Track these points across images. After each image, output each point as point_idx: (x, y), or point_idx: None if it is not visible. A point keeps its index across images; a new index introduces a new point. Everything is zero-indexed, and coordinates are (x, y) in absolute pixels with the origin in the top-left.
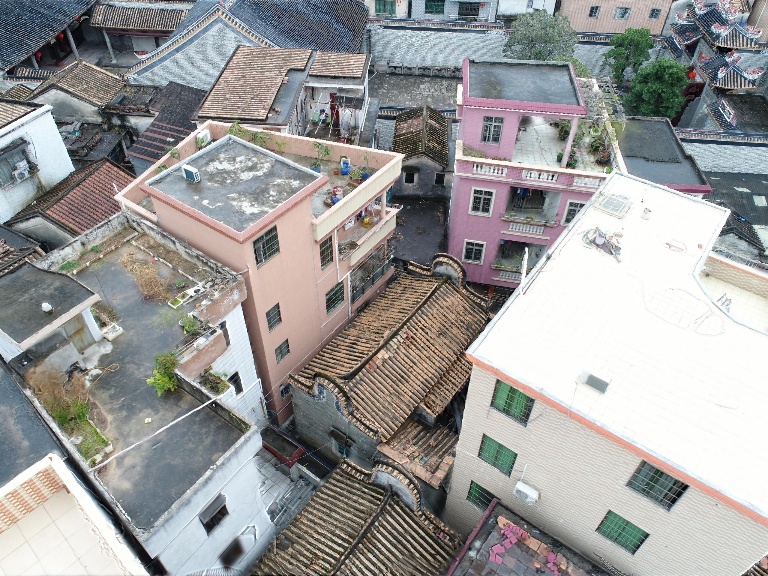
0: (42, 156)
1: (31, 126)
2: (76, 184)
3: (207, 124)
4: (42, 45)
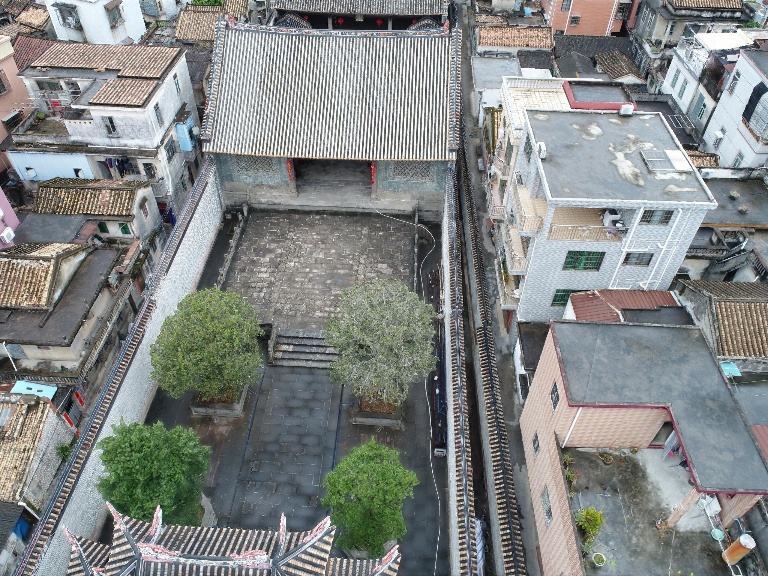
0: (88, 25)
1: (82, 4)
2: (44, 38)
3: (4, 37)
4: (324, 12)
